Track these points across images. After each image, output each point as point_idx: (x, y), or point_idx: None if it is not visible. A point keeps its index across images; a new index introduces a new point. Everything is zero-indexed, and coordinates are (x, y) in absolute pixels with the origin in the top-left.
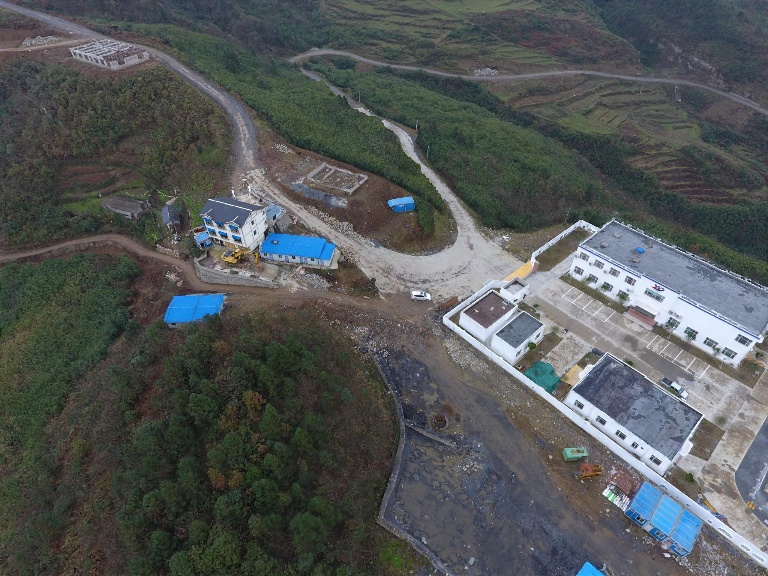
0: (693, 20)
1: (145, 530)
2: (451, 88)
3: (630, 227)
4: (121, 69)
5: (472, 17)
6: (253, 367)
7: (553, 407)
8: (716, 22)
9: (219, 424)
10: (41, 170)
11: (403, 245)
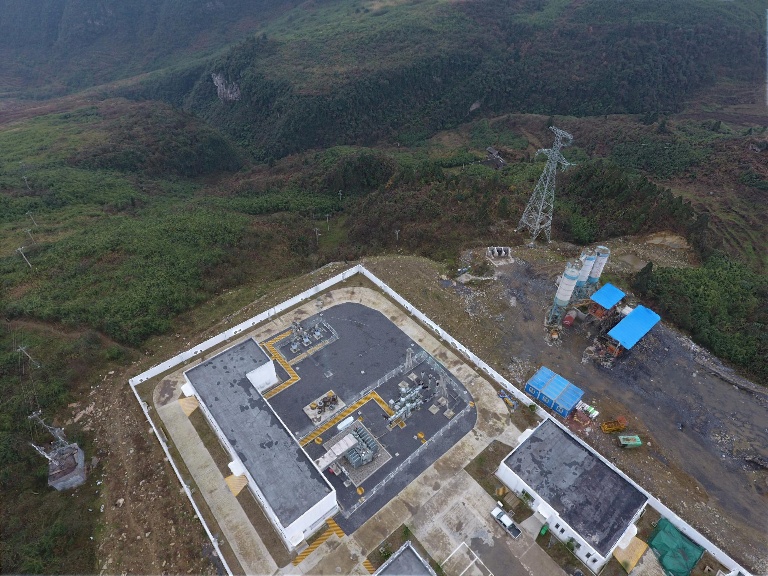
0: None
1: None
2: None
3: None
4: None
5: None
6: None
7: None
8: None
9: None
10: None
11: None
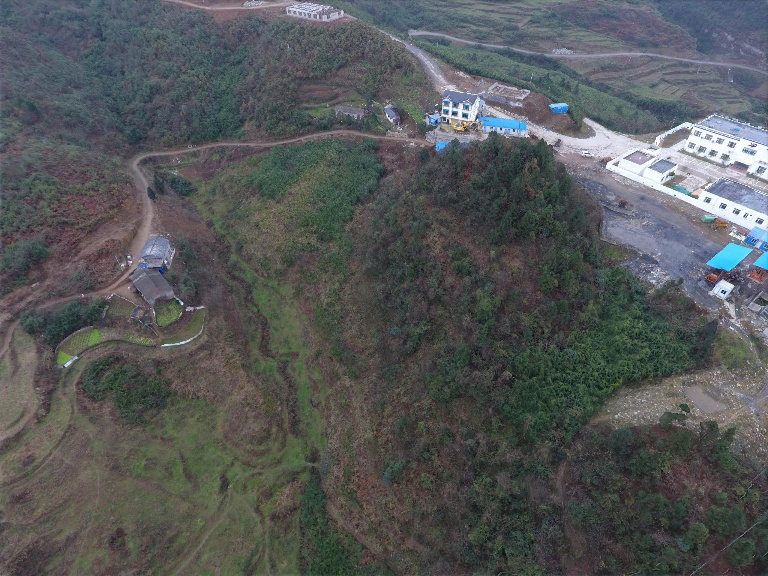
0: (746, 12)
1: (500, 210)
2: (534, 63)
3: (727, 118)
4: None
5: (549, 6)
6: (535, 148)
7: (689, 204)
8: (767, 13)
9: (523, 172)
10: (290, 86)
11: (564, 131)
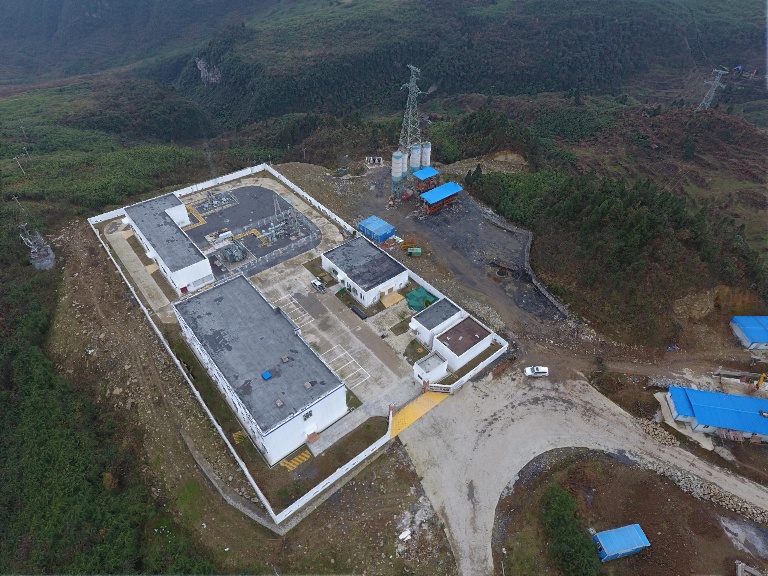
0: None
1: None
2: None
3: (251, 415)
4: None
5: None
6: None
7: None
8: None
9: None
10: None
11: None
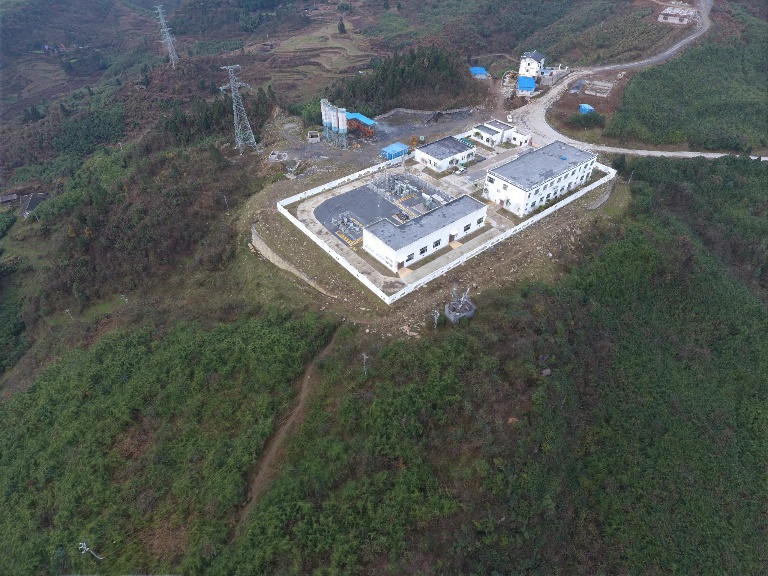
0: None
1: None
2: None
3: (590, 158)
4: (662, 22)
5: None
6: None
7: None
8: None
9: None
10: None
11: (553, 117)
